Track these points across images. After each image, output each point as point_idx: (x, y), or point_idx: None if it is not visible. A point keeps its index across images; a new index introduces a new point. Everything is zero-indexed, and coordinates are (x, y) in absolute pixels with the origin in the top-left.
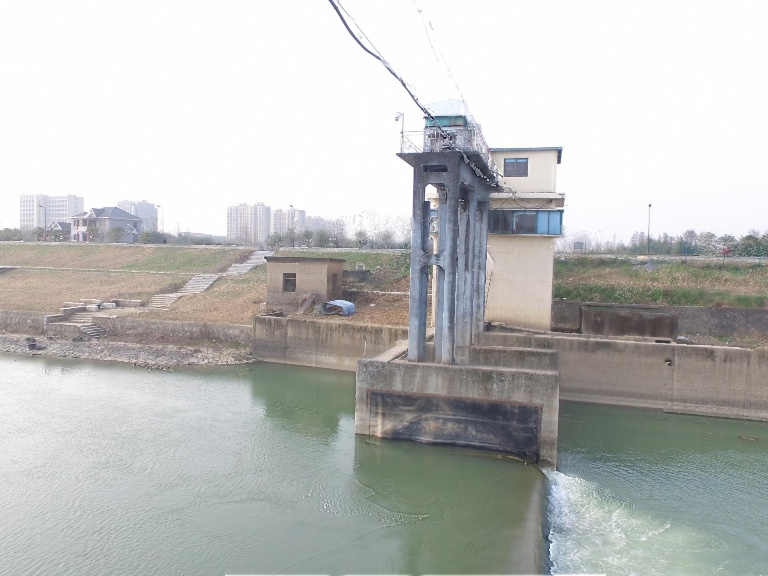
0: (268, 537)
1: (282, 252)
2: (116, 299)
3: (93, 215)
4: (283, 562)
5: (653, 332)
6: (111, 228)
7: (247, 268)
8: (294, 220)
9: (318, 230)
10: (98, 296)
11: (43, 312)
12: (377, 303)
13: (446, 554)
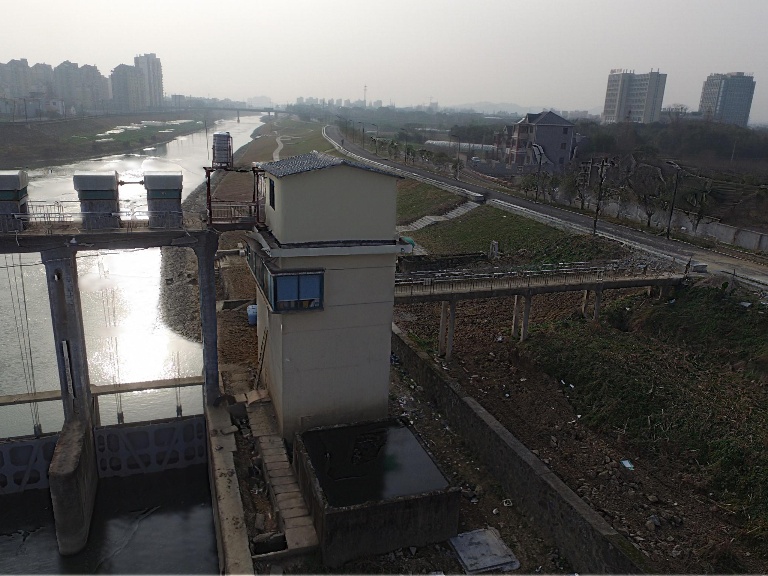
0: None
1: (480, 207)
2: None
3: (526, 121)
4: None
5: (315, 518)
6: (537, 135)
7: (425, 224)
8: (541, 163)
9: (568, 177)
10: None
11: None
12: None
13: None
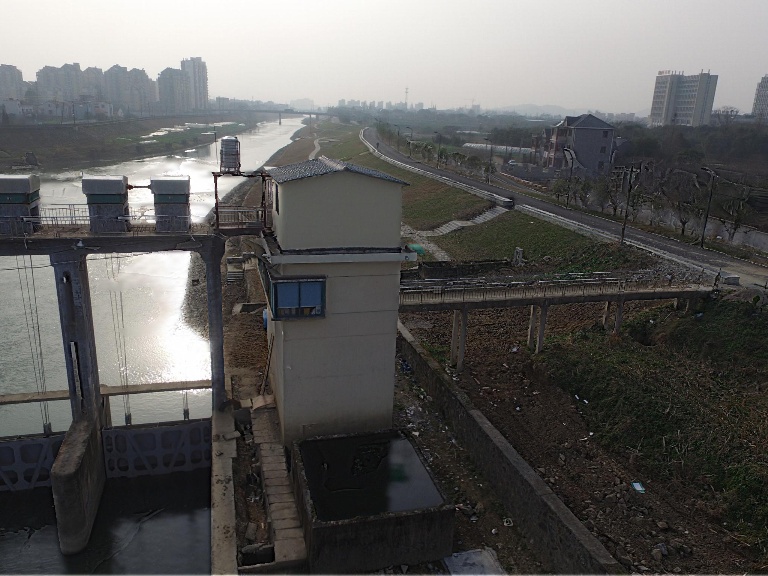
0: None
1: (508, 212)
2: None
3: (565, 124)
4: None
5: (305, 530)
6: (576, 138)
7: (451, 229)
8: (572, 167)
9: (601, 182)
10: None
11: None
12: None
13: None
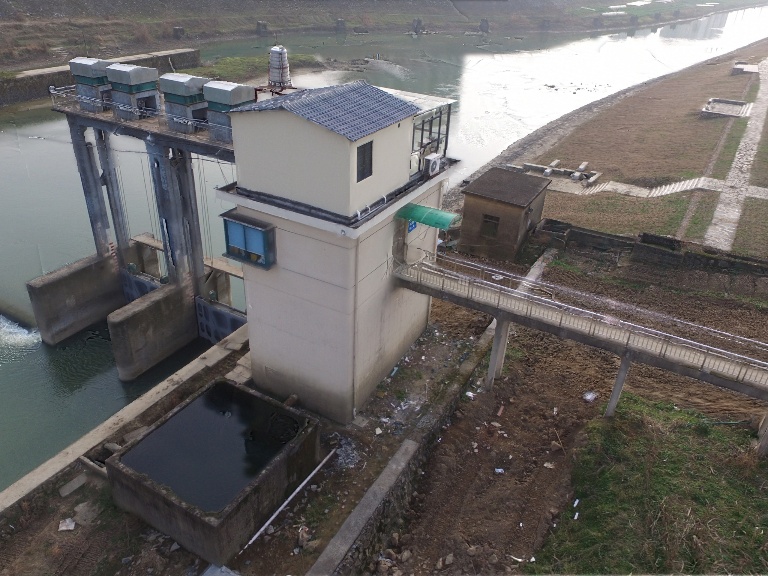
0: (66, 249)
1: None
2: (598, 172)
3: None
4: (44, 250)
5: None
6: None
7: None
8: None
9: None
10: (605, 164)
11: (534, 162)
12: None
13: (6, 279)
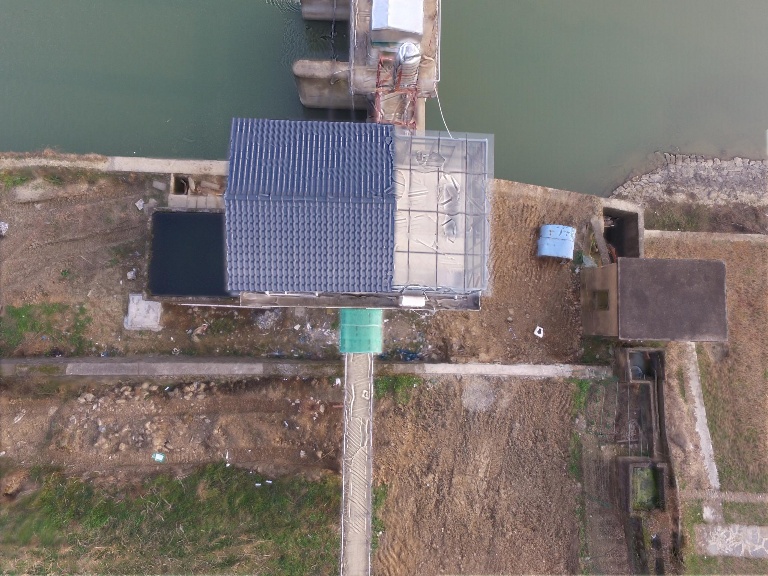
0: None
1: None
2: None
3: None
4: None
5: None
6: None
7: None
8: None
9: None
10: None
11: None
12: (538, 346)
13: None
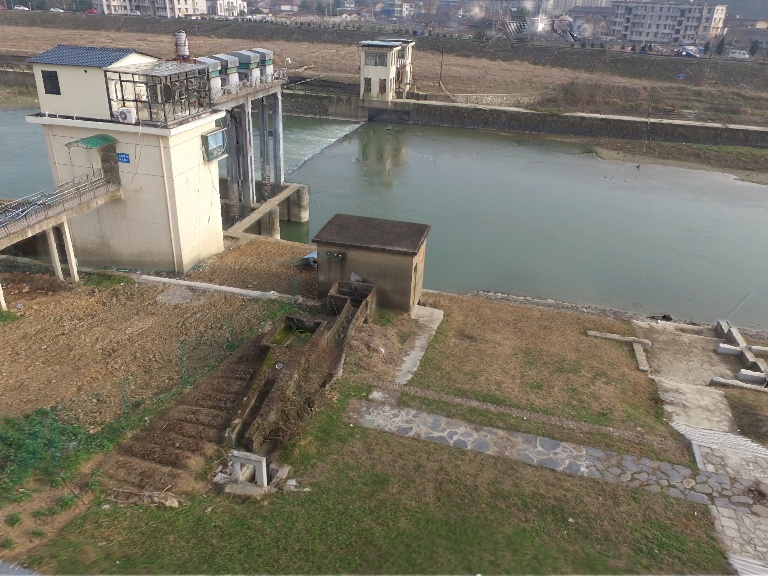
0: (335, 196)
1: None
2: None
3: None
4: None
5: None
6: None
7: None
8: None
9: None
10: None
11: None
12: None
13: None
